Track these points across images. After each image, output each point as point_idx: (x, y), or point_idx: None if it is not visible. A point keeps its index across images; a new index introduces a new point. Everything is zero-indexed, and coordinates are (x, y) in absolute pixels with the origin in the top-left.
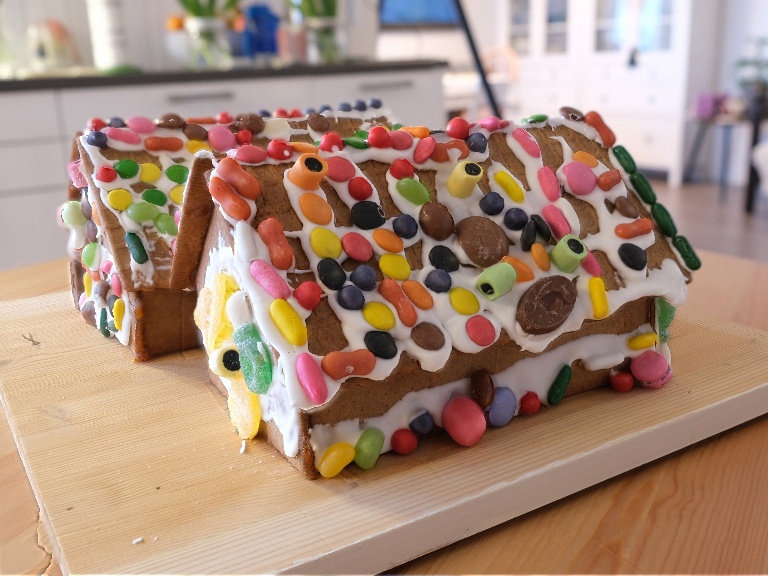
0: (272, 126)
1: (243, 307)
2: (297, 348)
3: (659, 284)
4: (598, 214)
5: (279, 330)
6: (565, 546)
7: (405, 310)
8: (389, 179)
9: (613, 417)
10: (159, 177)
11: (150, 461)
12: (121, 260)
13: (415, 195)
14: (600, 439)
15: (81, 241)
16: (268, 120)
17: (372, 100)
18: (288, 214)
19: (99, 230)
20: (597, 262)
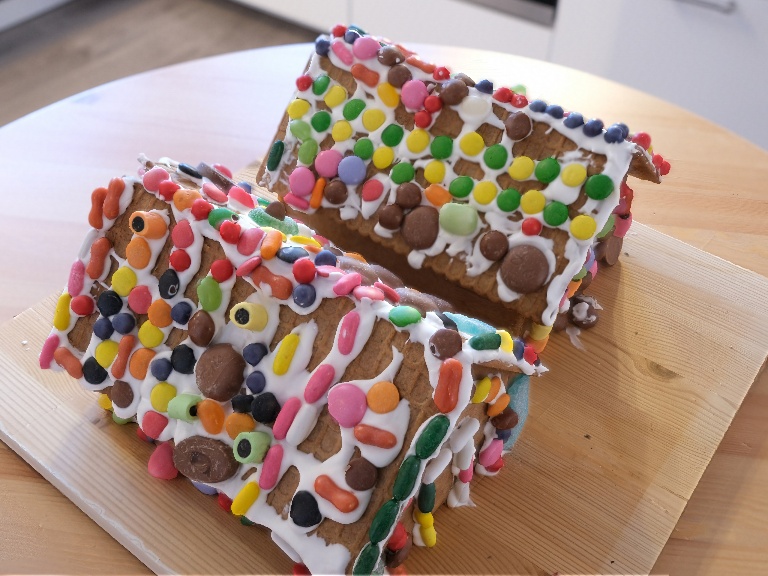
0: (465, 105)
1: None
2: None
3: (308, 551)
4: (340, 449)
5: None
6: (89, 575)
7: None
8: None
9: (236, 575)
10: (337, 105)
11: None
12: None
13: None
14: (187, 569)
15: None
16: (471, 96)
17: (611, 129)
18: (128, 242)
19: None
20: (269, 477)
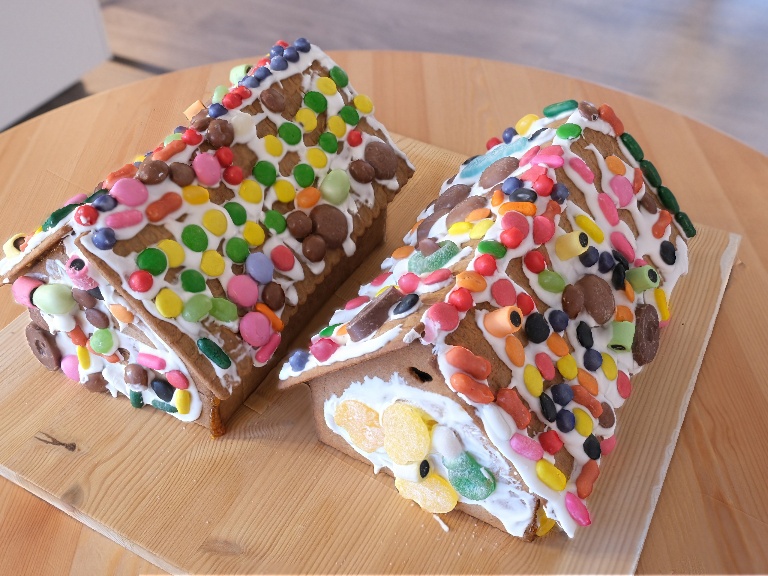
0: (242, 129)
1: (456, 443)
2: (561, 492)
3: (681, 266)
4: (634, 217)
5: (547, 485)
6: (694, 509)
7: (598, 410)
8: (530, 276)
9: (660, 376)
10: (184, 254)
11: (386, 575)
12: (204, 372)
13: (557, 288)
14: (673, 409)
15: (72, 324)
16: (233, 121)
17: (300, 43)
18: (500, 368)
19: (123, 325)
20: None
